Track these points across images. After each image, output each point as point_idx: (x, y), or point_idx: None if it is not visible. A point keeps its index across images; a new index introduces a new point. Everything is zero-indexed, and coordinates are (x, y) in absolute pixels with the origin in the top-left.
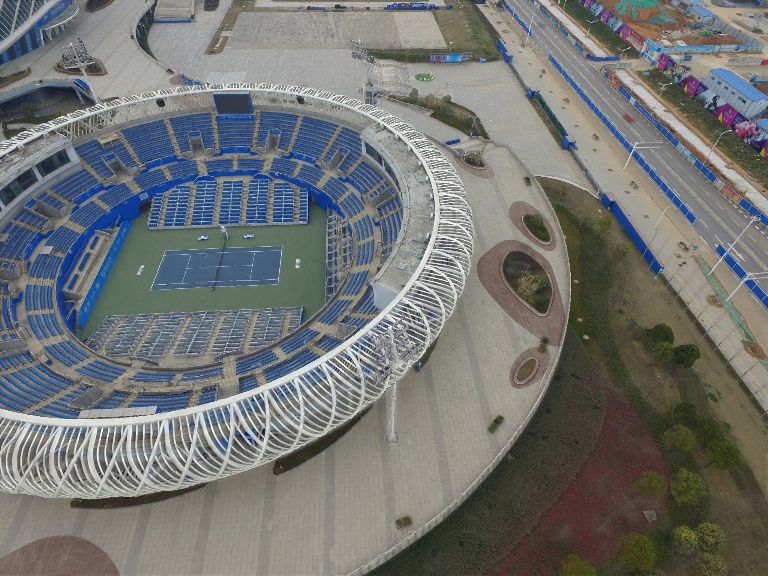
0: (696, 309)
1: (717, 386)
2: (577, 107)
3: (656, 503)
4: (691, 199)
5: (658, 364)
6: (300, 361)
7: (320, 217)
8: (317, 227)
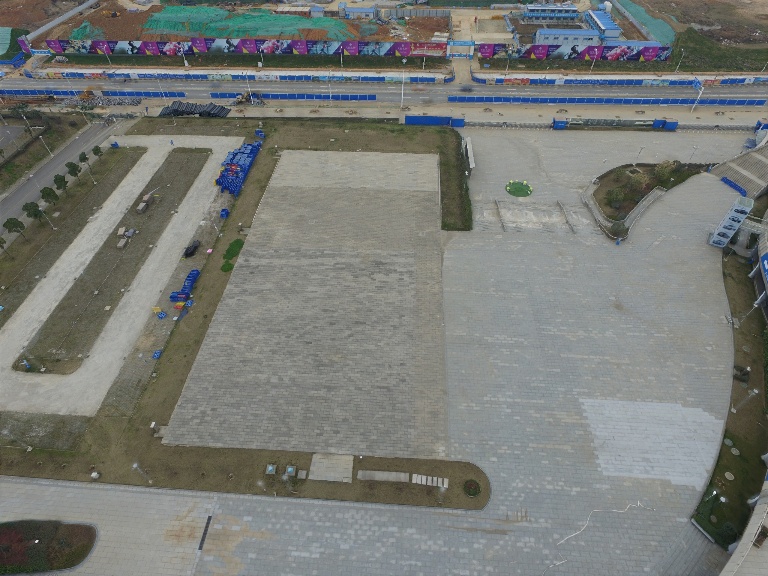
0: None
1: None
2: (574, 109)
3: None
4: None
5: None
6: None
7: None
8: None
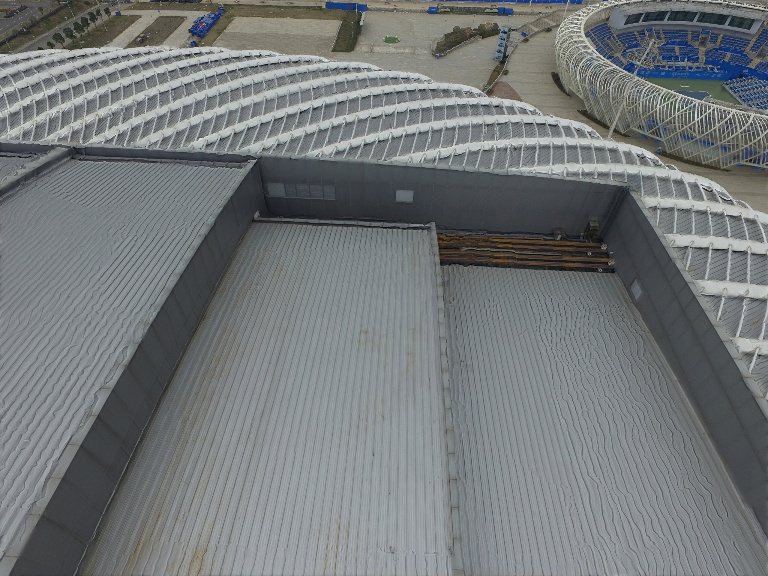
0: None
1: None
2: (449, 4)
3: None
4: None
5: None
6: None
7: None
8: None
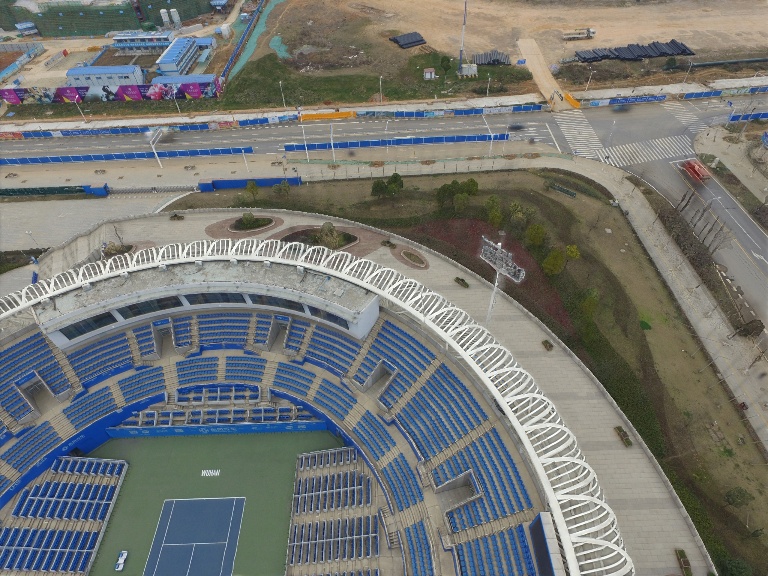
0: (340, 176)
1: (407, 185)
2: (31, 172)
3: (493, 229)
4: (222, 145)
5: (392, 203)
6: (415, 420)
7: (120, 447)
8: (141, 451)
